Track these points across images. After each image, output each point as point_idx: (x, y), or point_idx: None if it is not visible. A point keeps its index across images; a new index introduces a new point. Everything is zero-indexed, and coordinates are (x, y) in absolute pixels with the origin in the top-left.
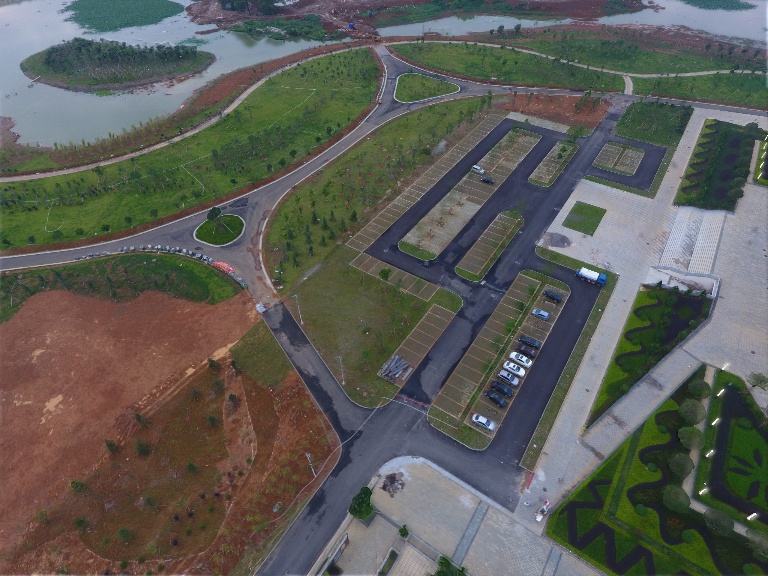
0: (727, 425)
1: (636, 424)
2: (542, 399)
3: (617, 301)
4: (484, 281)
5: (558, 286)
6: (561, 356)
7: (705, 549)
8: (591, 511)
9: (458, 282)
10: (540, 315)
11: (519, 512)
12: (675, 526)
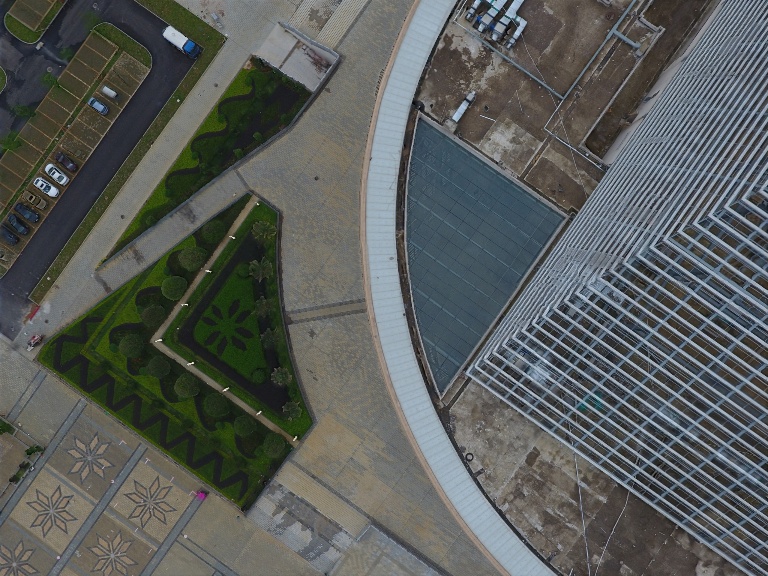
0: (227, 272)
1: (153, 260)
2: (70, 226)
3: (206, 86)
4: (40, 43)
5: (137, 56)
6: (108, 170)
7: (156, 381)
8: (74, 345)
9: (5, 44)
10: (94, 109)
11: (17, 341)
12: (137, 363)
